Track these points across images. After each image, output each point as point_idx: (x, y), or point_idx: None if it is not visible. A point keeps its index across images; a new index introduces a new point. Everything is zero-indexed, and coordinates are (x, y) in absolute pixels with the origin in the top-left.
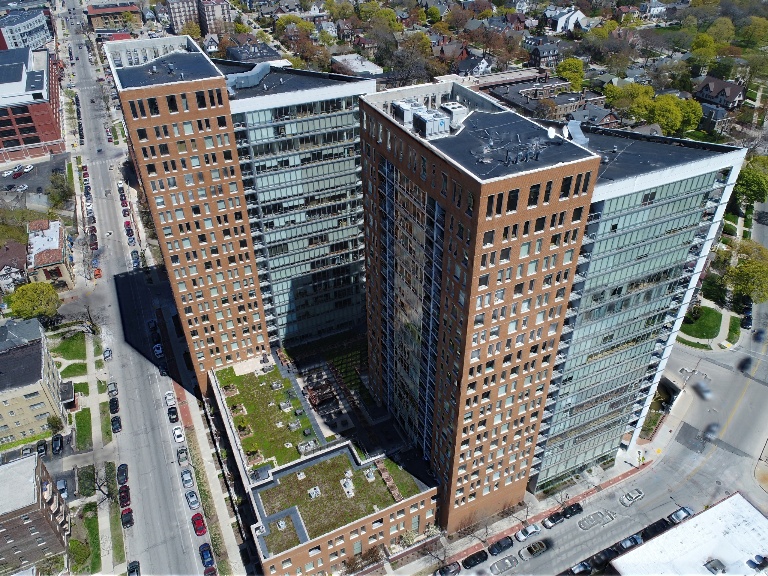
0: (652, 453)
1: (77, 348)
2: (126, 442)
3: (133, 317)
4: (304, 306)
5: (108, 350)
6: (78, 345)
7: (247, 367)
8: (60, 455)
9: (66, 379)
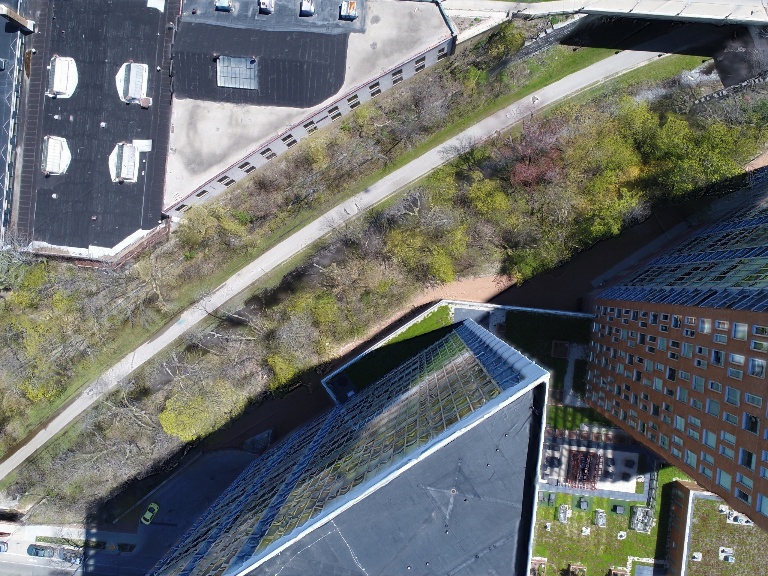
0: None
1: None
2: None
3: None
4: None
5: None
6: None
7: None
8: None
9: None
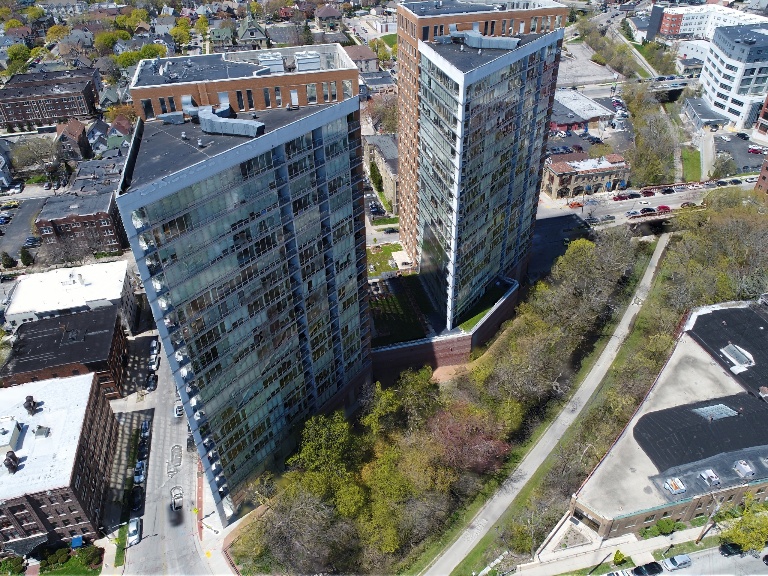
0: (209, 545)
1: None
2: (375, 236)
3: None
4: (427, 253)
5: None
6: None
7: (400, 256)
8: (369, 214)
9: None
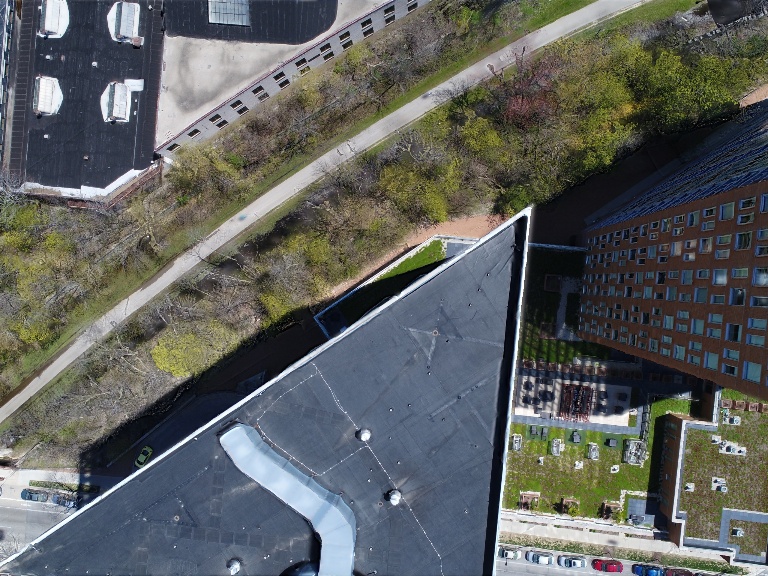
0: None
1: None
2: None
3: None
4: None
5: None
6: None
7: None
8: None
9: None
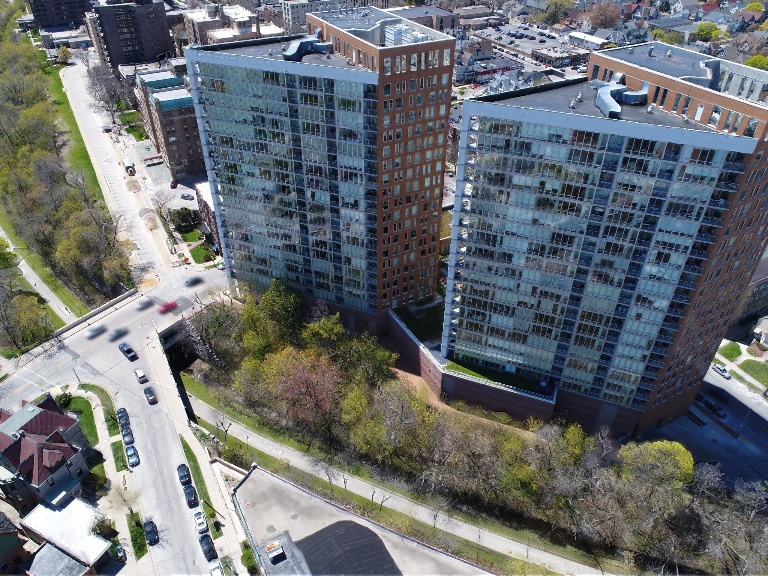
0: None
1: (762, 375)
2: None
3: (754, 422)
4: None
5: (725, 371)
6: (766, 379)
7: None
8: None
9: (727, 343)
